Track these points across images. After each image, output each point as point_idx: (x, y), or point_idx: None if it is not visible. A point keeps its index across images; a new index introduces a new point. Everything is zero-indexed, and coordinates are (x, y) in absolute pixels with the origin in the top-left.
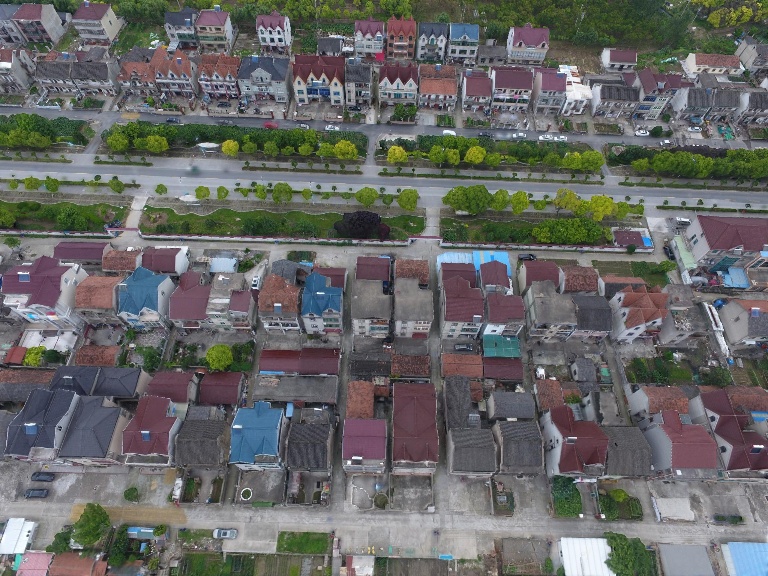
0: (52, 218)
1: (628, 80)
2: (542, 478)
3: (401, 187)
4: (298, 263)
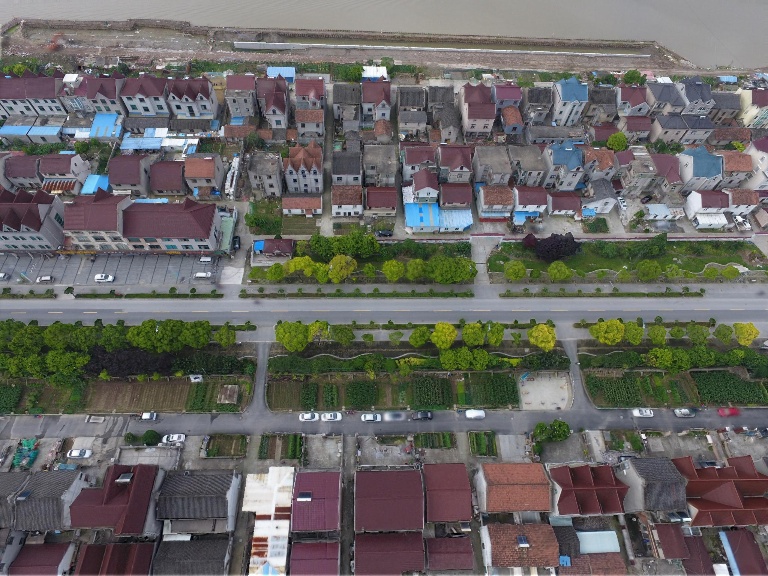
0: None
1: (145, 567)
2: (391, 104)
3: (523, 309)
4: (596, 201)
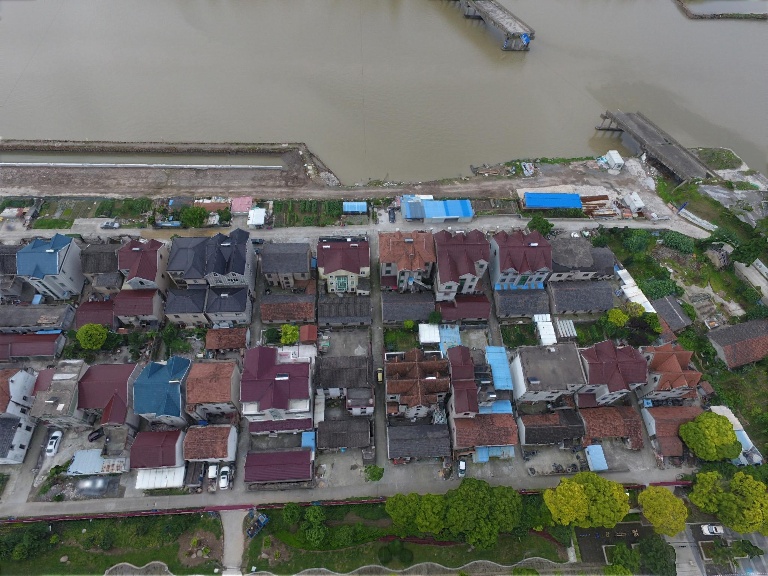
0: (343, 526)
1: None
2: None
3: None
4: None
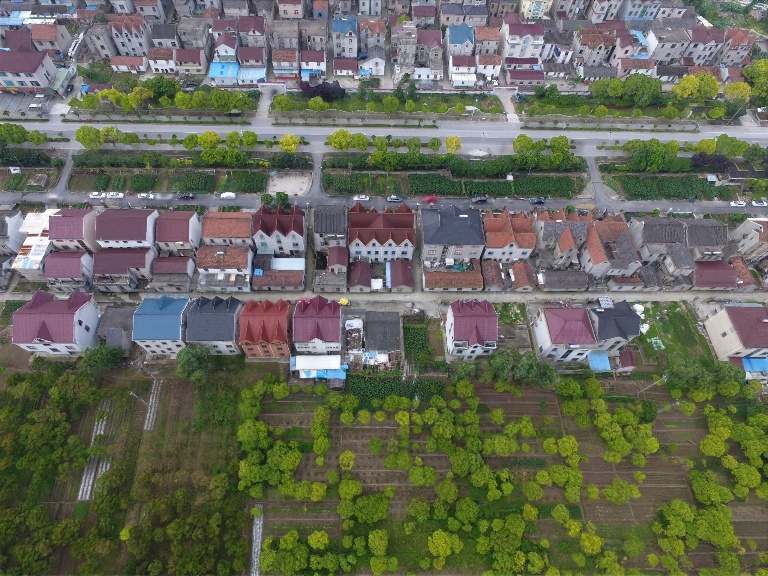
0: None
1: None
2: None
3: None
4: (367, 61)
